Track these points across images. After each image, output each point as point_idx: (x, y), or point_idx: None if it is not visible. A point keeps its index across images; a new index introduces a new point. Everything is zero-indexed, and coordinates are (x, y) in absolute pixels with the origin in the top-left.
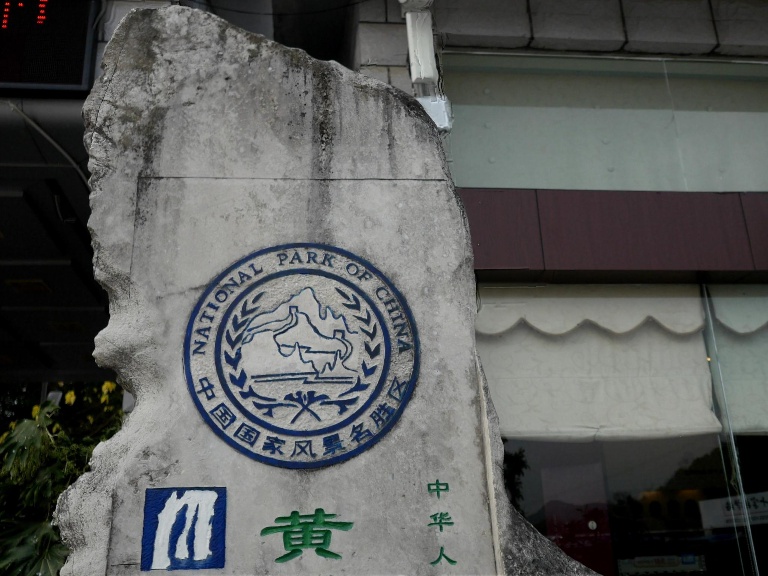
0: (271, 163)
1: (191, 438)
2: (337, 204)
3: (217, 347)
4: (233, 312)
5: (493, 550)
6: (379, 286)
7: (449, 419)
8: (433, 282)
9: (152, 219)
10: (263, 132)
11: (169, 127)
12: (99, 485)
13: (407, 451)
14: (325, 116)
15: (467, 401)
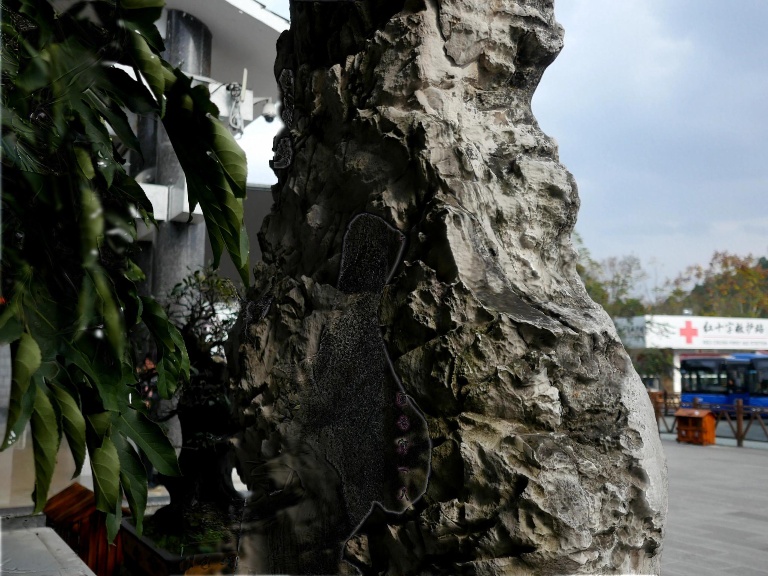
0: None
1: None
2: None
3: None
4: None
5: None
6: None
7: None
8: None
9: None
10: None
11: None
12: None
13: None
14: None
15: None
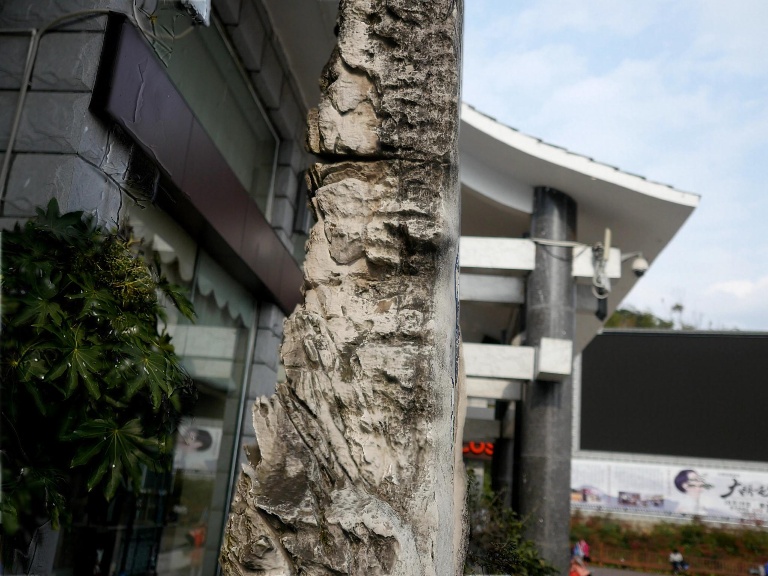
0: None
1: None
2: None
3: None
4: None
5: None
6: None
7: None
8: None
9: None
10: None
11: None
12: None
13: None
14: None
15: None
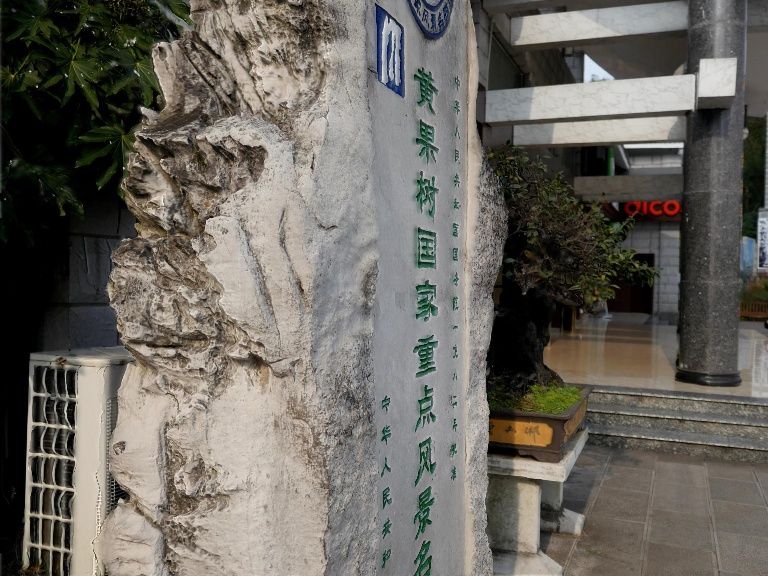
0: None
1: None
2: None
3: None
4: None
5: (467, 136)
6: None
7: None
8: None
9: None
10: None
11: None
12: None
13: None
14: None
15: None
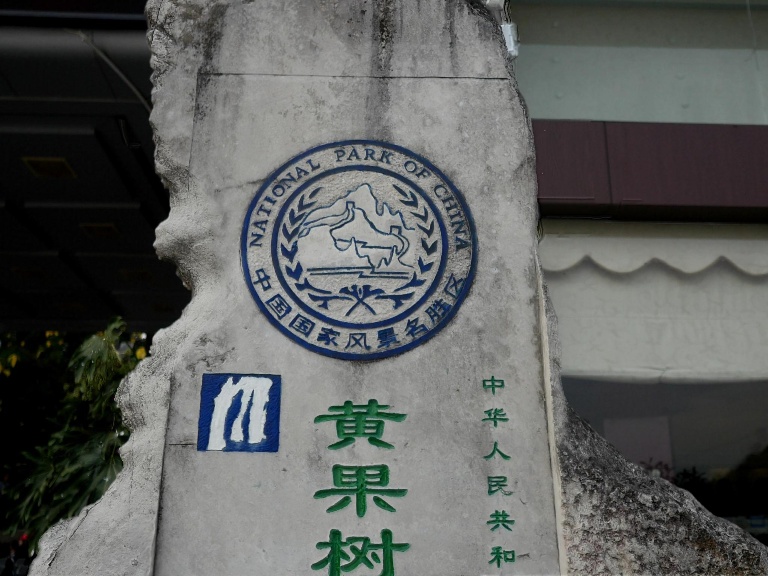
0: (330, 60)
1: (247, 327)
2: (396, 102)
3: (274, 240)
4: (290, 206)
5: (548, 447)
6: (437, 184)
7: (506, 317)
8: (493, 181)
9: (211, 114)
10: (322, 29)
11: (228, 24)
12: (158, 369)
13: (462, 347)
14: (386, 14)
15: (525, 300)
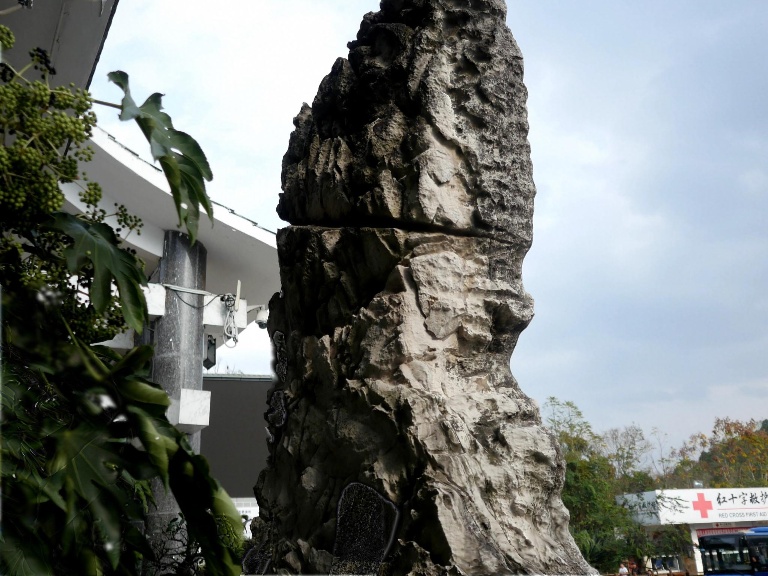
0: None
1: None
2: None
3: None
4: None
5: None
6: None
7: None
8: None
9: None
10: None
11: None
12: None
13: None
14: None
15: None
